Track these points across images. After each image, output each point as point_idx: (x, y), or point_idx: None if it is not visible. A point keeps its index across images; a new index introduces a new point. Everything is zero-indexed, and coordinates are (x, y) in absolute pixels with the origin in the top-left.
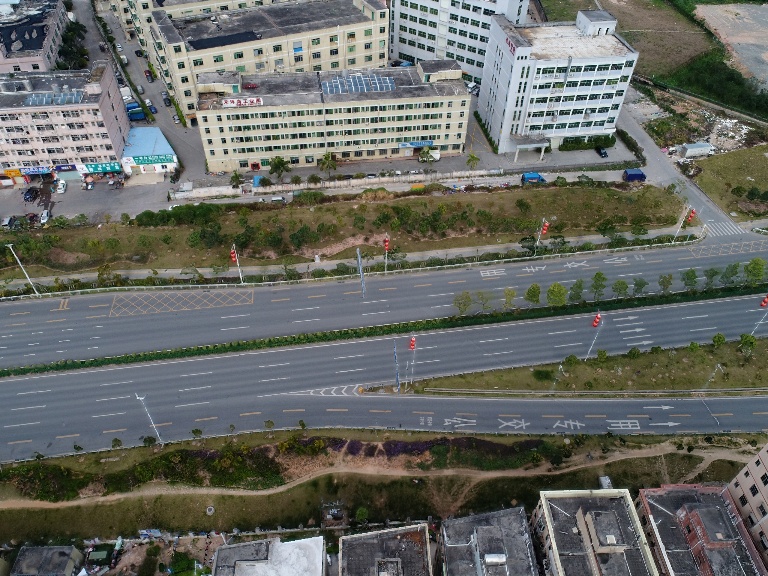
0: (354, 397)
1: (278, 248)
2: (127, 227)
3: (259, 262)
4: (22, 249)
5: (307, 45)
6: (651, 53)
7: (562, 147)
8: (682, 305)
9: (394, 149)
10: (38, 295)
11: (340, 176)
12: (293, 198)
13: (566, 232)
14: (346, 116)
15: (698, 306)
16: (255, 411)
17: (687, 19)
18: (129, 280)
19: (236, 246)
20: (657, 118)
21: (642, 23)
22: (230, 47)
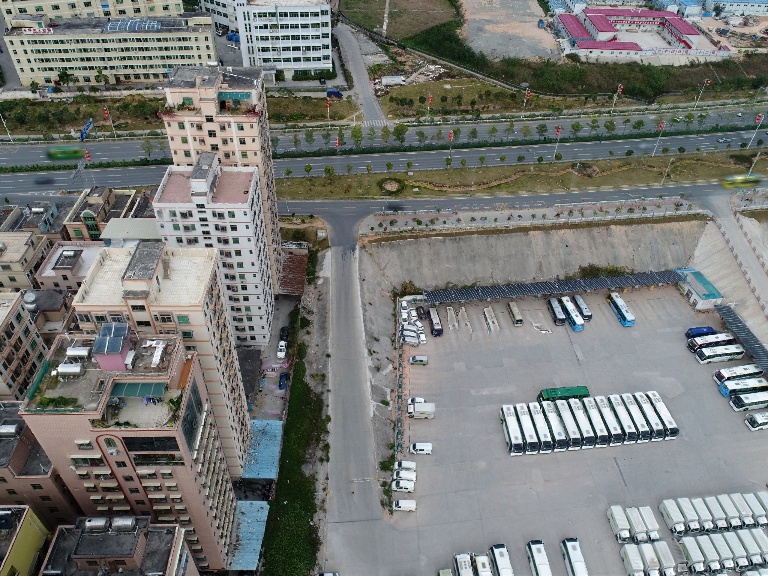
0: (56, 196)
1: (47, 124)
2: None
3: (31, 133)
4: None
5: (113, 3)
6: (406, 25)
7: (294, 77)
8: (311, 158)
9: (164, 74)
10: None
11: (113, 87)
12: (73, 99)
13: None
14: (119, 45)
15: (321, 159)
16: None
17: (450, 4)
18: None
19: (18, 124)
20: (381, 63)
21: (412, 5)
22: (48, 0)
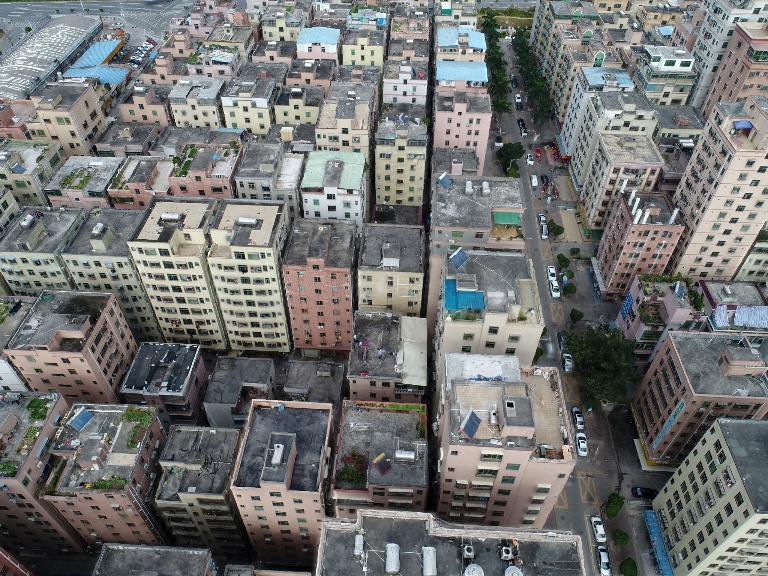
0: None
1: None
2: None
3: None
4: None
5: None
6: None
7: None
8: None
9: None
10: None
11: None
12: None
13: None
14: None
15: None
16: (514, 5)
17: None
18: None
19: None
20: None
21: None
22: None
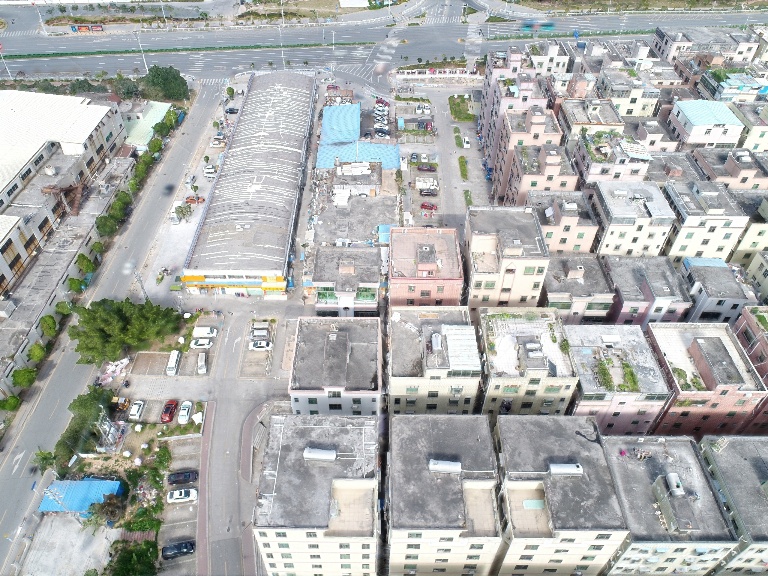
0: None
1: None
2: None
3: (710, 6)
4: None
5: None
6: None
7: None
8: None
9: None
10: (608, 13)
11: None
12: None
13: None
14: None
15: None
16: None
17: None
18: (652, 8)
19: None
20: None
21: None
22: None
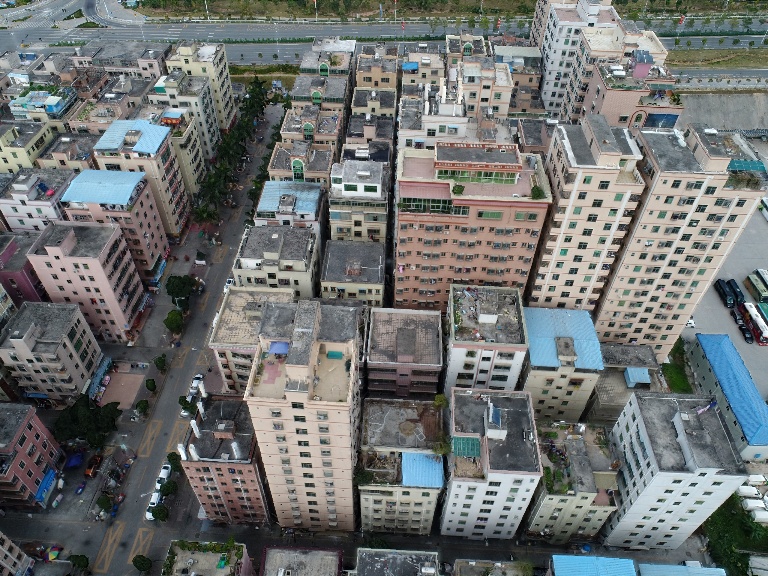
0: None
1: (336, 11)
2: (252, 1)
3: (326, 17)
4: (200, 0)
5: None
6: None
7: None
8: None
9: None
10: (209, 21)
11: None
12: None
13: (502, 14)
14: None
15: None
16: None
17: None
18: None
19: (313, 10)
20: None
21: None
22: None
